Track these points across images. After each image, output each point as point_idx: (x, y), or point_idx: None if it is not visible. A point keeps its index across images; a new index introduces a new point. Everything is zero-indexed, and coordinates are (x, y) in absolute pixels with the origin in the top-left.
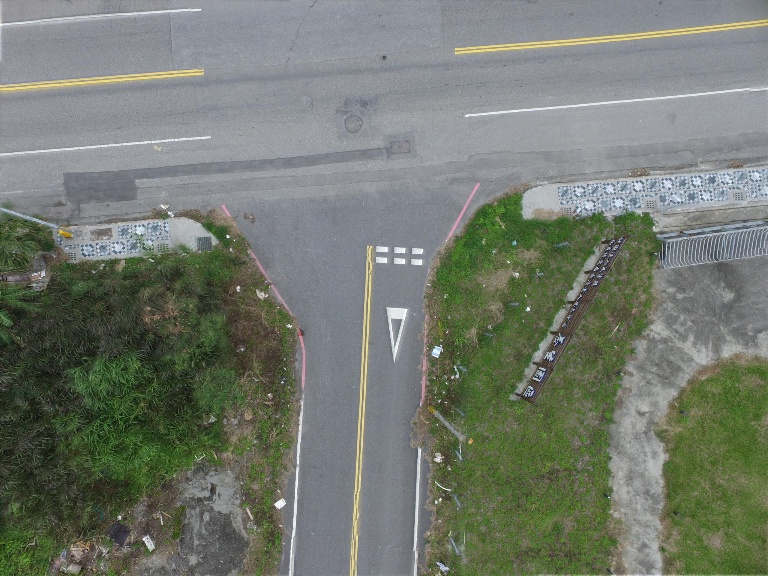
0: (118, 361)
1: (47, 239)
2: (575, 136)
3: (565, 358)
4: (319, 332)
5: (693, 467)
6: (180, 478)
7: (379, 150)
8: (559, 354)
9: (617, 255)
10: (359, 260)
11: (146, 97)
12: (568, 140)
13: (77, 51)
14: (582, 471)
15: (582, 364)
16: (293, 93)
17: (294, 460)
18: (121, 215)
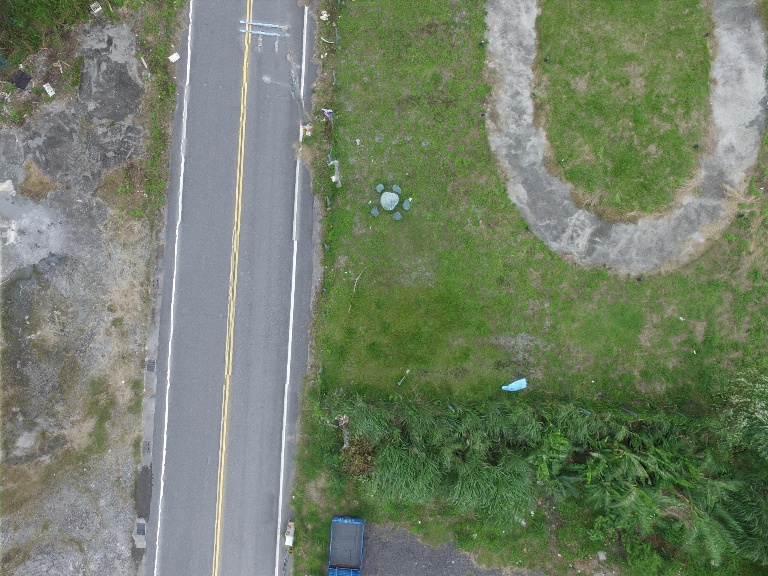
0: None
1: None
2: None
3: None
4: None
5: (563, 17)
6: (78, 30)
7: None
8: None
9: None
10: None
11: None
12: None
13: None
14: (459, 24)
15: None
16: None
17: (187, 18)
18: None
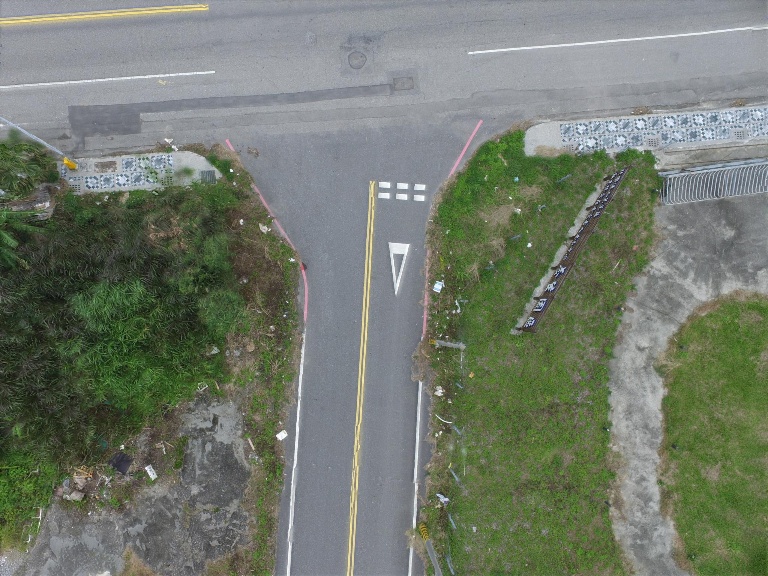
0: (122, 284)
1: (52, 171)
2: (578, 74)
3: (566, 294)
4: (321, 266)
5: (692, 401)
6: (182, 408)
7: (382, 86)
8: (560, 283)
9: (619, 185)
10: (362, 195)
11: (151, 31)
12: (571, 78)
13: None
14: (582, 405)
15: (583, 300)
16: (297, 29)
17: (296, 392)
18: (125, 148)
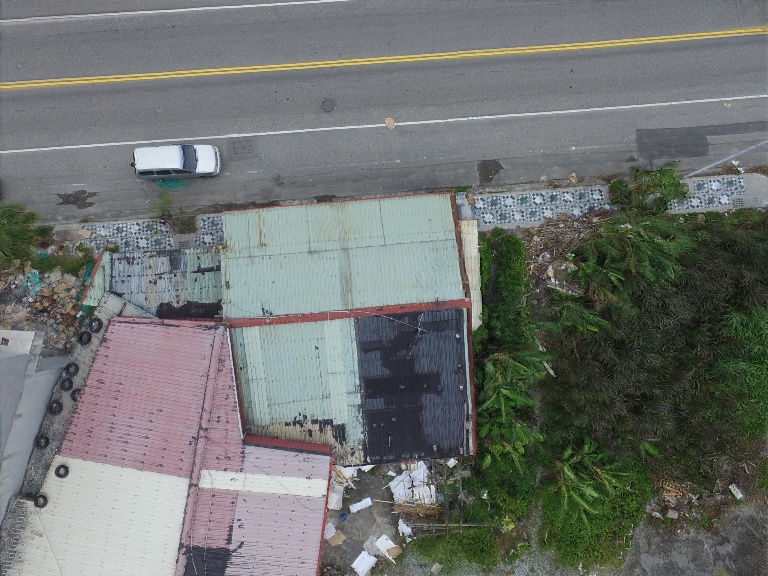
0: None
1: None
2: None
3: None
4: None
5: None
6: (763, 428)
7: None
8: None
9: None
10: None
11: (713, 56)
12: None
13: (648, 10)
14: None
15: None
16: None
17: None
18: (692, 171)
